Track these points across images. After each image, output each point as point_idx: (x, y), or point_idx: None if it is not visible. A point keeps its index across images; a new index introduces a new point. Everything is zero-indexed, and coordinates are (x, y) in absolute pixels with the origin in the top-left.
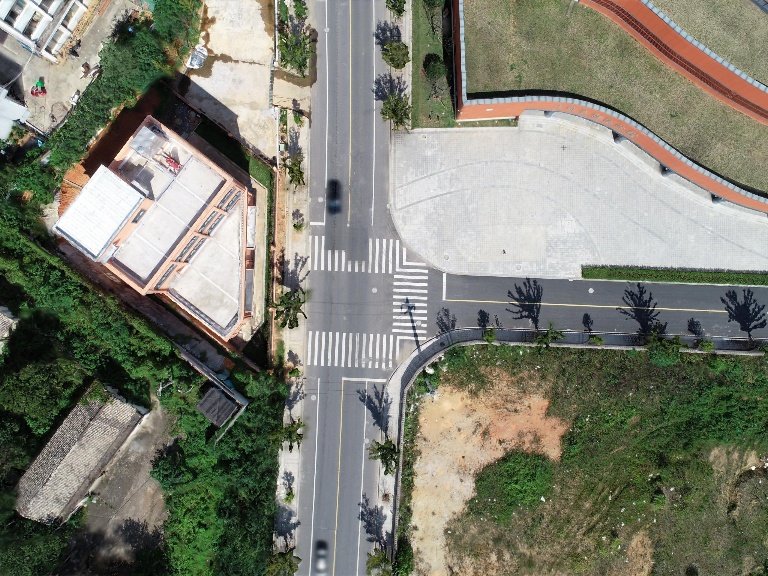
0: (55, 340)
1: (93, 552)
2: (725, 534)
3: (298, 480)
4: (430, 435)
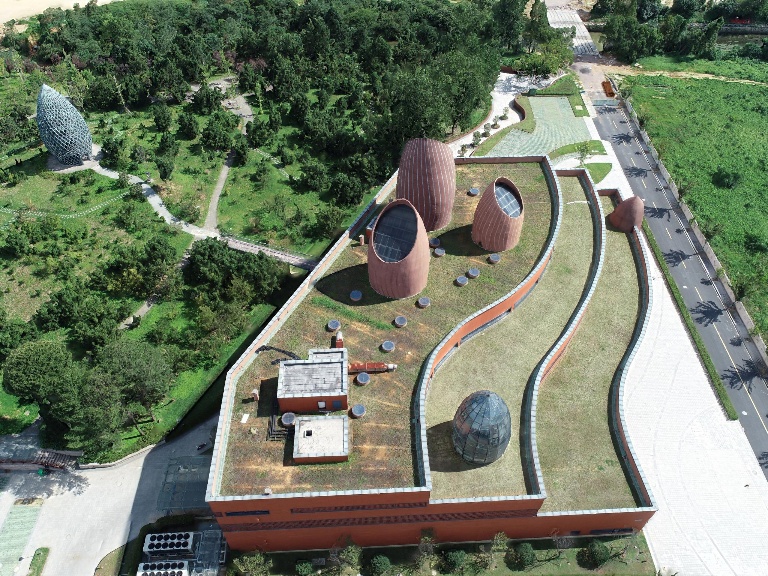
0: None
1: None
2: None
3: None
4: None
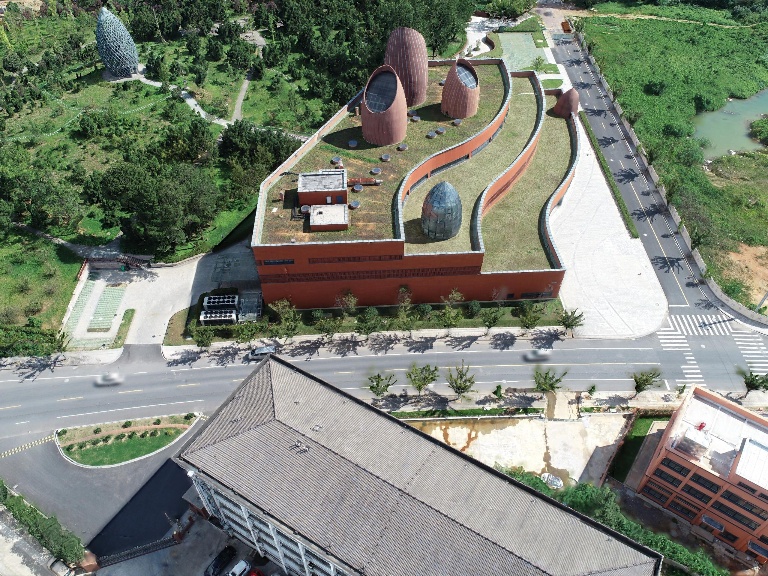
0: None
1: None
2: (761, 181)
3: None
4: None
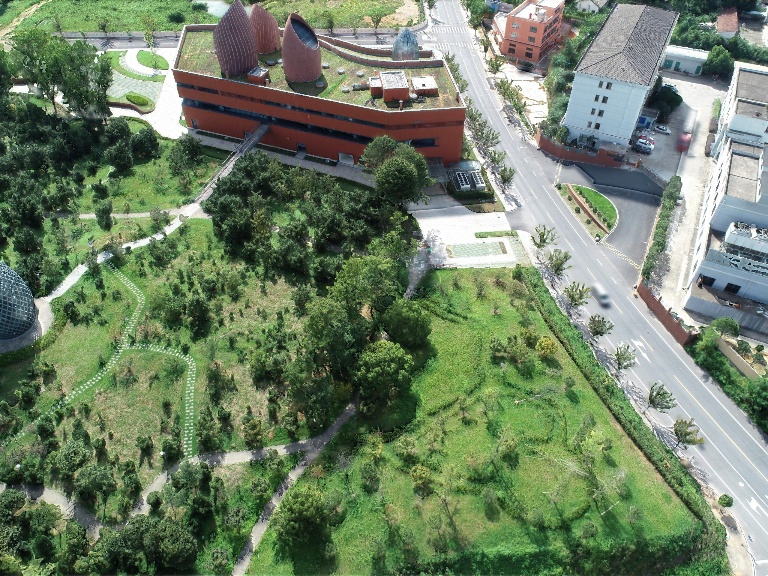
0: None
1: None
2: (300, 8)
3: None
4: (415, 18)
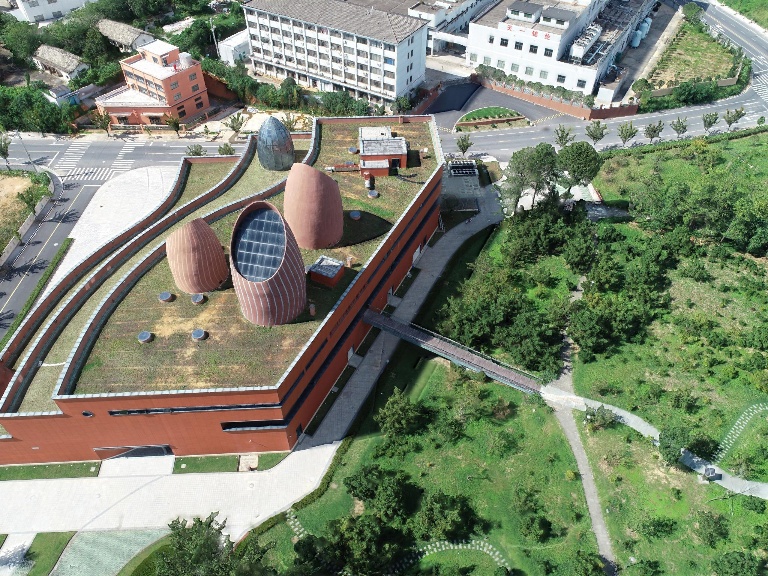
0: (119, 59)
1: (16, 73)
2: None
3: (12, 139)
4: (4, 181)
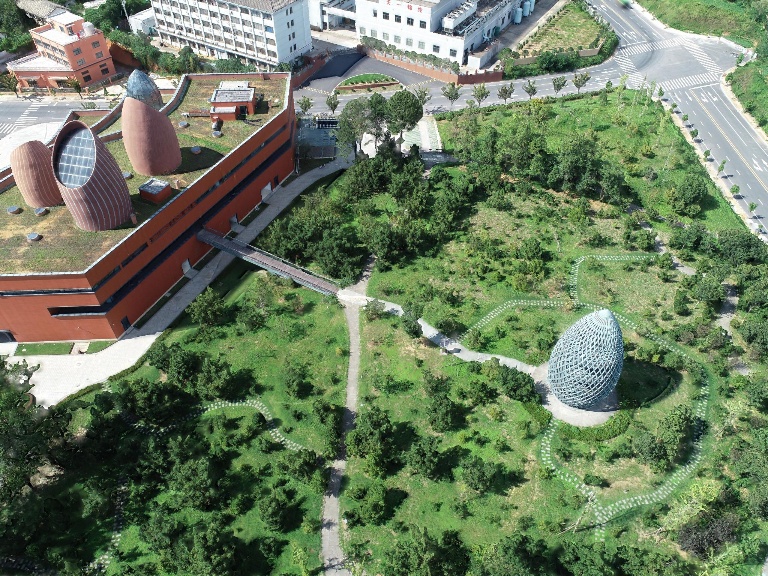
0: None
1: None
2: None
3: None
4: None
